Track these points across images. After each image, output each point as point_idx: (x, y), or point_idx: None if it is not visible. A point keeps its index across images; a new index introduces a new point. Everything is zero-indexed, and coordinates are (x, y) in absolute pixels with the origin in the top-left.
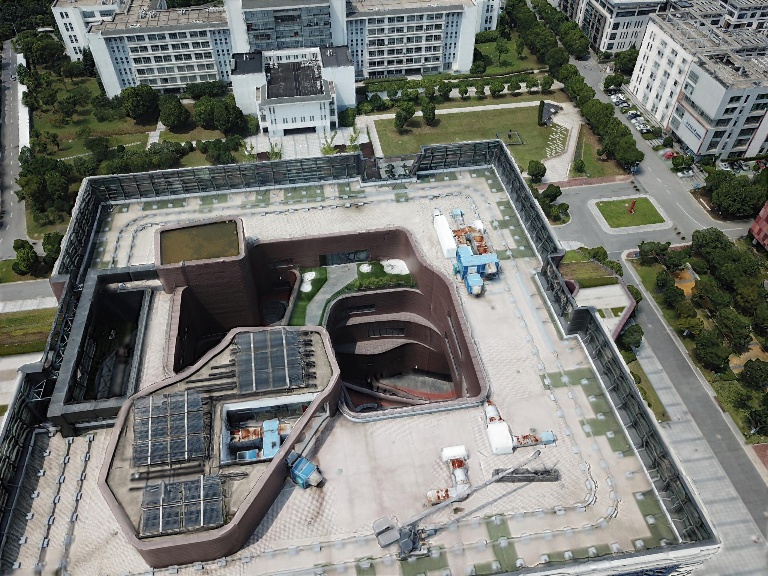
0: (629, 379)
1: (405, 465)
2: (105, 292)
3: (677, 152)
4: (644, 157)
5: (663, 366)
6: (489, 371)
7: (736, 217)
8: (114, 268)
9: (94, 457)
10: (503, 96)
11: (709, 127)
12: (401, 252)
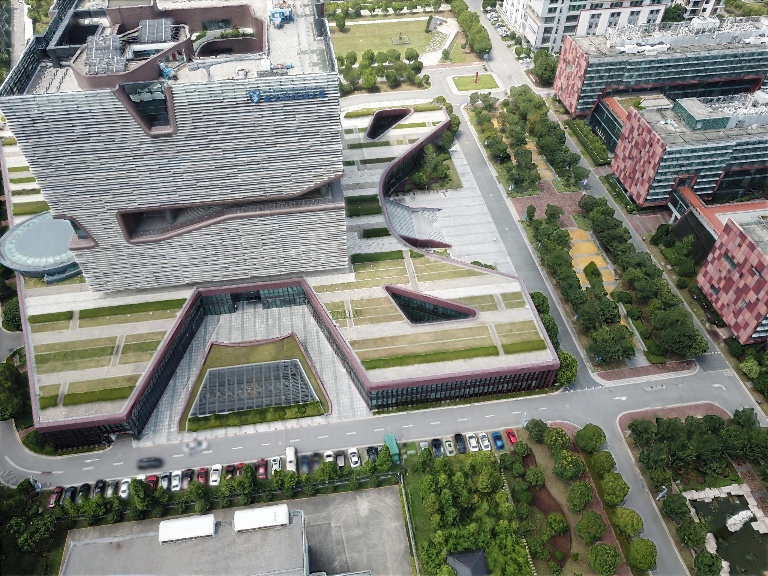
0: (328, 37)
1: (218, 75)
2: (78, 25)
3: (524, 48)
4: (498, 51)
5: (468, 162)
6: (272, 50)
7: (552, 85)
8: (82, 10)
9: (69, 73)
10: (403, 14)
11: (540, 24)
12: (249, 22)
